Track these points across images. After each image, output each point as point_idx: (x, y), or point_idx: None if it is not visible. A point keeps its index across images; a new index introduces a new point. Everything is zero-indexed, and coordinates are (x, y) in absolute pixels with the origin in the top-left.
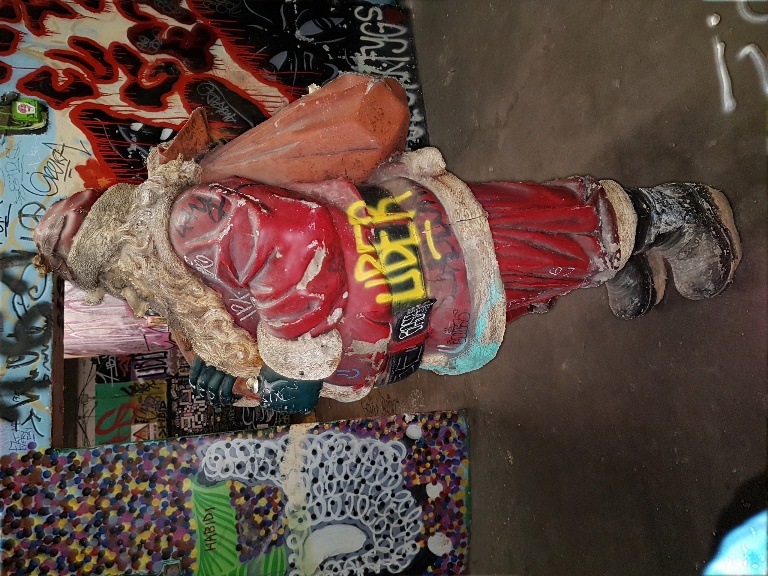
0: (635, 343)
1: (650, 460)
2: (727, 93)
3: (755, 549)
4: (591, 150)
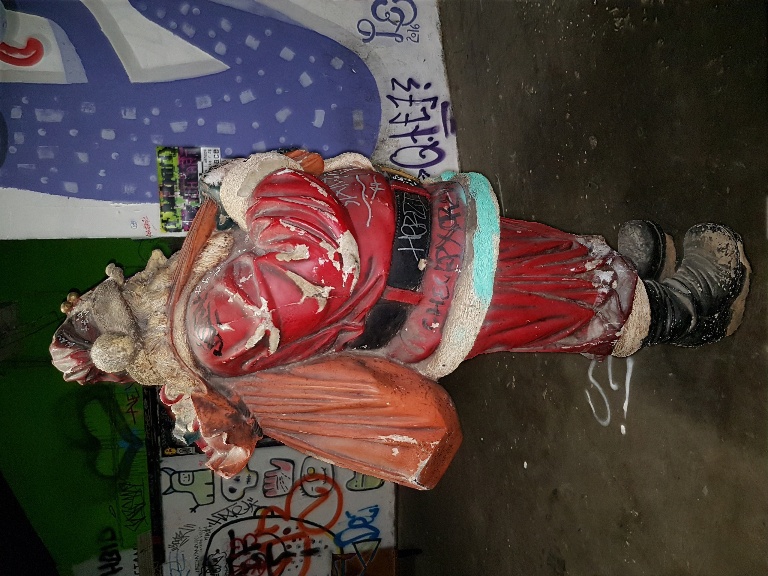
0: (764, 197)
1: (759, 48)
2: (629, 373)
3: (656, 6)
4: (763, 468)
